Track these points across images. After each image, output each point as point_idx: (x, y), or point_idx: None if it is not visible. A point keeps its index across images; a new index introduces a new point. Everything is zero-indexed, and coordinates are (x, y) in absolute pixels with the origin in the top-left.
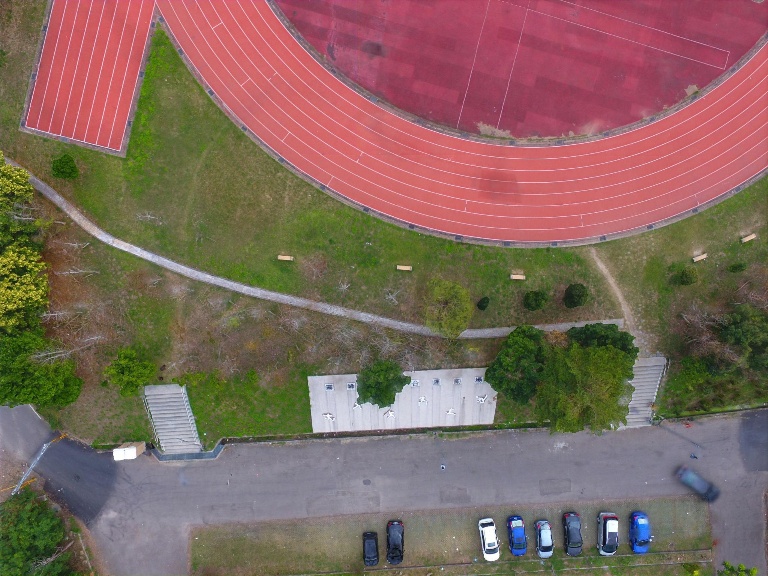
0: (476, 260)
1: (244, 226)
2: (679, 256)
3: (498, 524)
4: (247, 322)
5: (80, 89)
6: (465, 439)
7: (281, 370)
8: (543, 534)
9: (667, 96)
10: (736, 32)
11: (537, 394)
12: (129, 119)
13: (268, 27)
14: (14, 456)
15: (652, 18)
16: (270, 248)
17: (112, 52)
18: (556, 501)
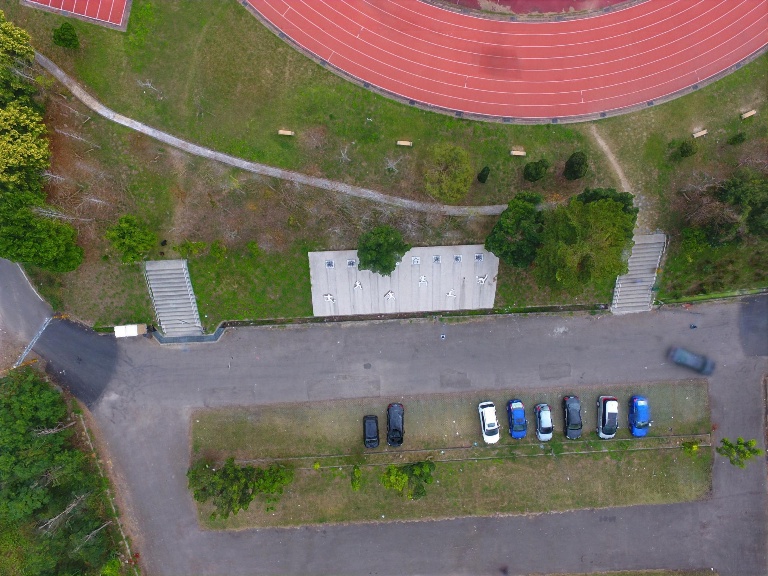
0: (476, 136)
1: (245, 101)
2: (679, 133)
3: (498, 408)
4: (248, 197)
5: None
6: (465, 323)
7: (282, 246)
8: (543, 415)
9: None
10: None
11: (537, 256)
12: None
13: None
14: (16, 338)
15: None
16: (271, 123)
17: None
18: (556, 386)
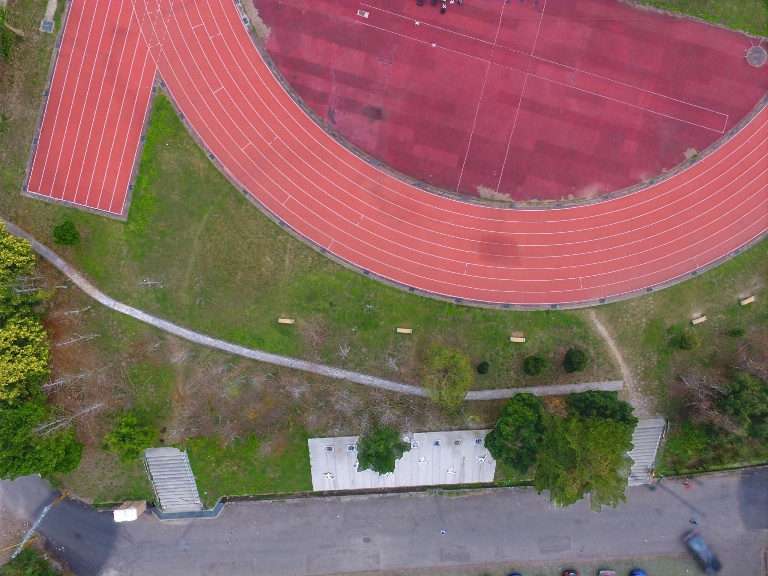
0: (476, 322)
1: (245, 289)
2: (678, 318)
3: None
4: (248, 385)
5: (82, 153)
6: (465, 497)
7: (281, 432)
8: None
9: (666, 159)
10: (735, 96)
11: (537, 463)
12: (130, 183)
13: (269, 91)
14: (15, 515)
15: (651, 82)
16: (271, 311)
17: (114, 117)
18: (556, 559)
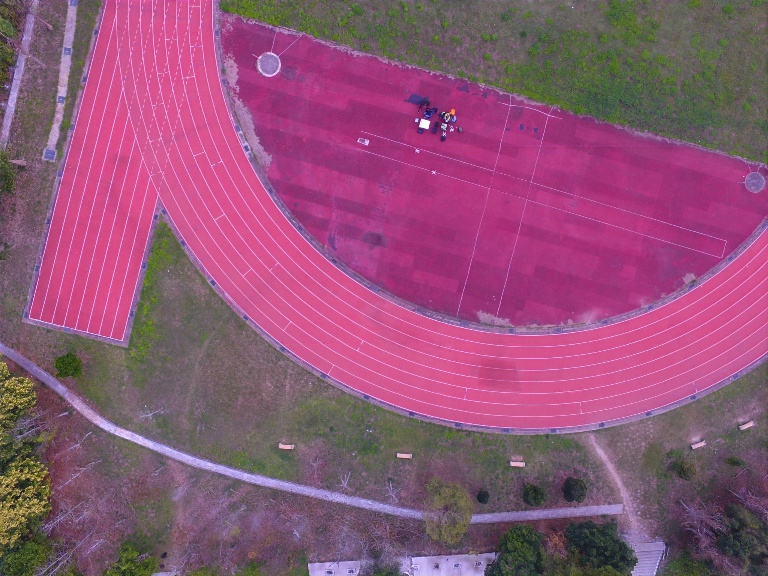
0: (476, 446)
1: (245, 414)
2: (677, 442)
3: None
4: (248, 509)
5: (83, 281)
6: None
7: (282, 556)
8: None
9: (665, 284)
10: (733, 222)
11: None
12: (132, 309)
13: (270, 218)
14: None
15: (650, 208)
16: (271, 436)
17: (115, 244)
18: None
